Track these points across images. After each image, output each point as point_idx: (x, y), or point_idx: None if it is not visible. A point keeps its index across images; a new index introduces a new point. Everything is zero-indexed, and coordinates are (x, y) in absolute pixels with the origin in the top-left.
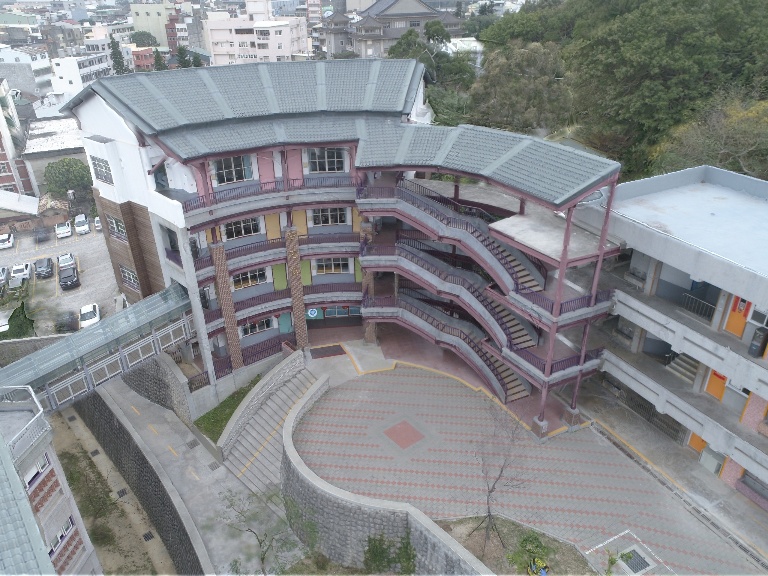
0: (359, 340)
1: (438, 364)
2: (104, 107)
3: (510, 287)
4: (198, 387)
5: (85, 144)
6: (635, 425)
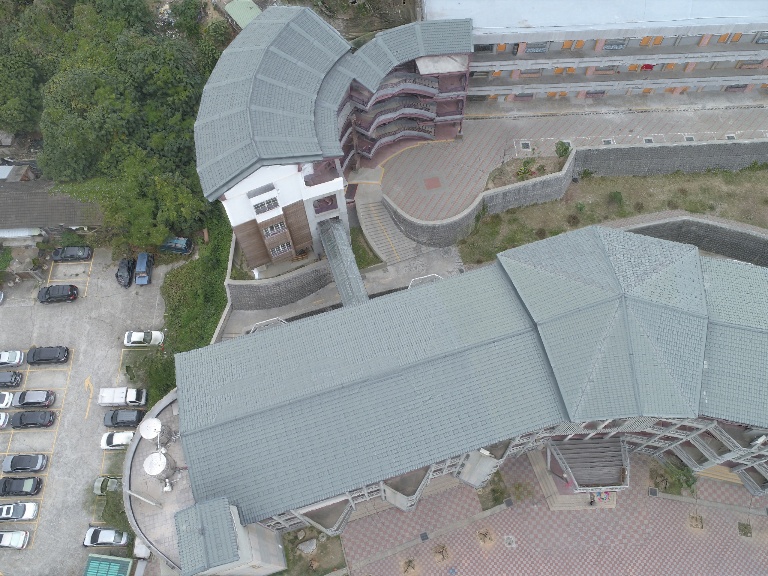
0: (350, 174)
1: (392, 150)
2: (274, 169)
3: (436, 93)
4: None
5: (232, 205)
6: (470, 107)
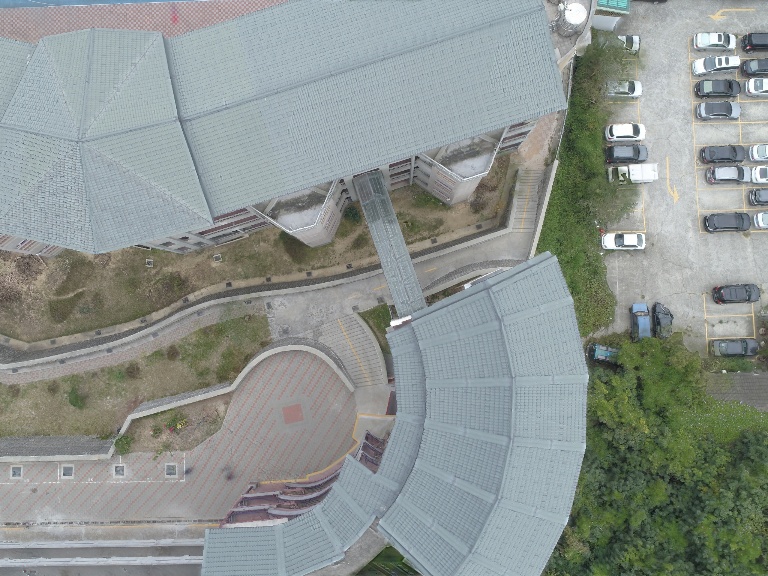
0: None
1: None
2: None
3: (272, 510)
4: (393, 311)
5: None
6: None
